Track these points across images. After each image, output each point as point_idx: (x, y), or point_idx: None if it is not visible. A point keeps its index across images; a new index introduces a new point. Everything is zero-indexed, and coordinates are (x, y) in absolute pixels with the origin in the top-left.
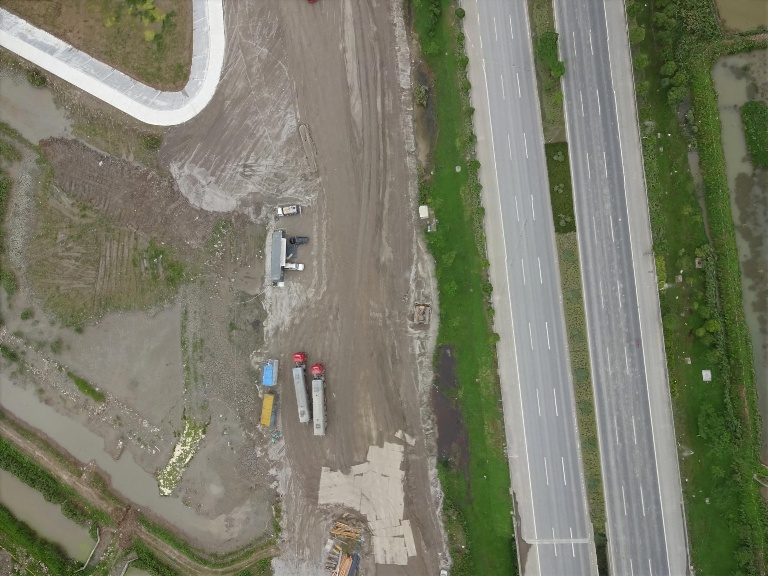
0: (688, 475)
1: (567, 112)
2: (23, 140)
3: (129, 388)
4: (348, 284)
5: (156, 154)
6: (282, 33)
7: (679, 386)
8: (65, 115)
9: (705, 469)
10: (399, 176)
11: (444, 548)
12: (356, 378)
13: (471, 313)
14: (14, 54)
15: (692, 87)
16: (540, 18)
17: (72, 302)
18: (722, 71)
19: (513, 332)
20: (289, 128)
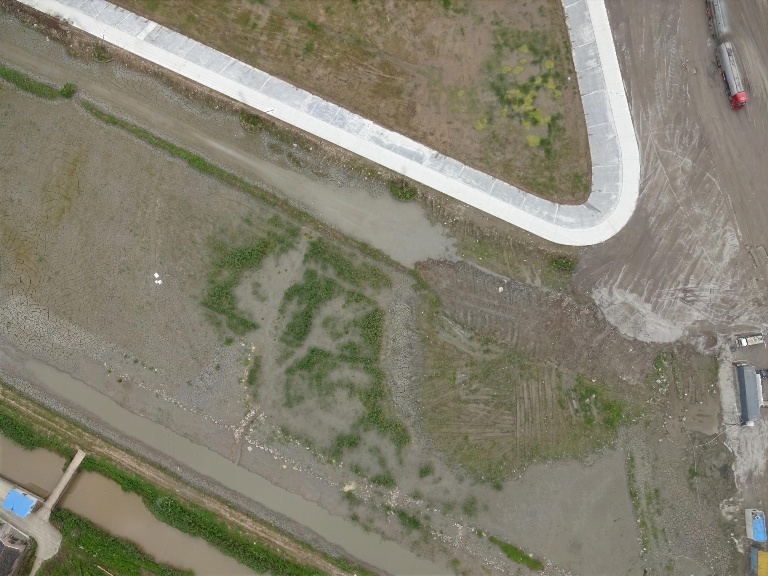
0: None
1: None
2: (394, 263)
3: (571, 551)
4: None
5: (569, 278)
6: (705, 142)
7: None
8: (444, 233)
9: None
10: None
11: None
12: None
13: None
14: (371, 162)
15: None
16: None
17: (487, 454)
18: None
19: None
20: (731, 247)
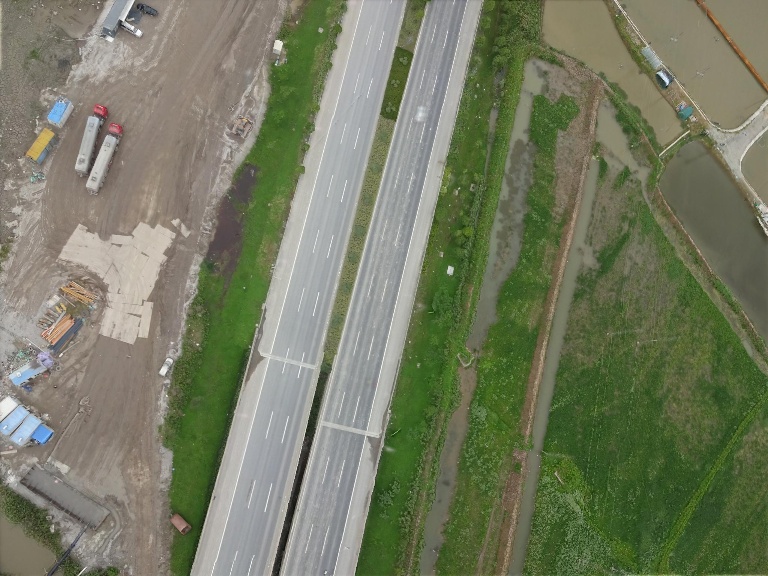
0: (412, 339)
1: (421, 33)
2: None
3: None
4: (181, 71)
5: None
6: None
7: (429, 269)
8: None
9: (425, 340)
10: (268, 8)
11: (179, 339)
12: (153, 156)
13: (286, 147)
14: None
15: (510, 65)
16: None
17: None
18: (531, 67)
19: (316, 177)
20: None
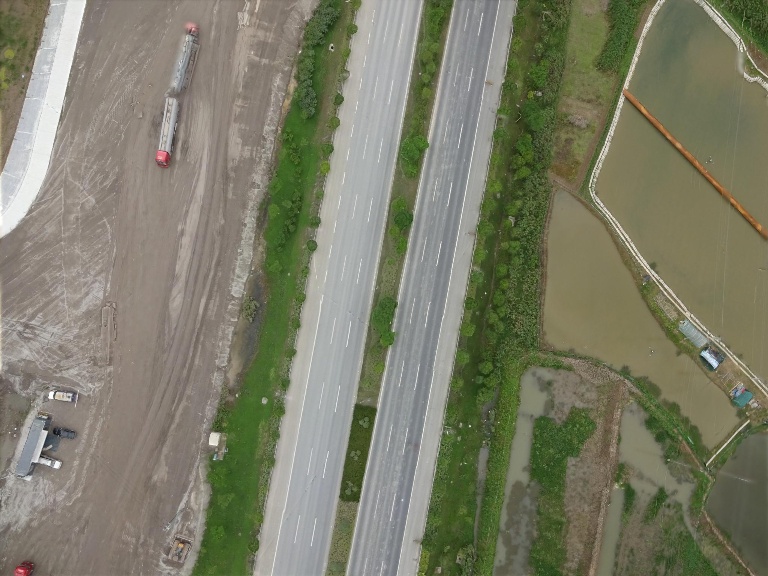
0: None
1: (386, 377)
2: None
3: None
4: (107, 496)
5: None
6: (118, 188)
7: None
8: None
9: None
10: (200, 391)
11: None
12: None
13: (232, 559)
14: None
15: (502, 387)
16: (388, 275)
17: None
18: (531, 379)
19: None
20: (93, 299)
